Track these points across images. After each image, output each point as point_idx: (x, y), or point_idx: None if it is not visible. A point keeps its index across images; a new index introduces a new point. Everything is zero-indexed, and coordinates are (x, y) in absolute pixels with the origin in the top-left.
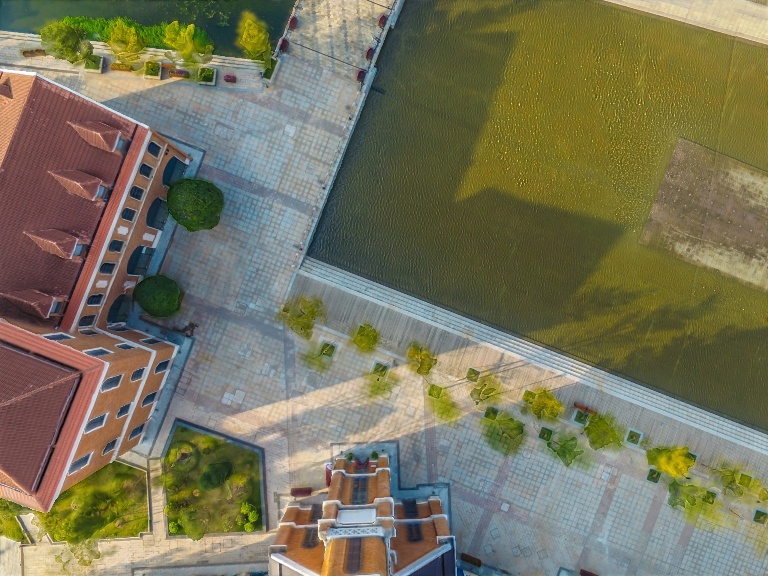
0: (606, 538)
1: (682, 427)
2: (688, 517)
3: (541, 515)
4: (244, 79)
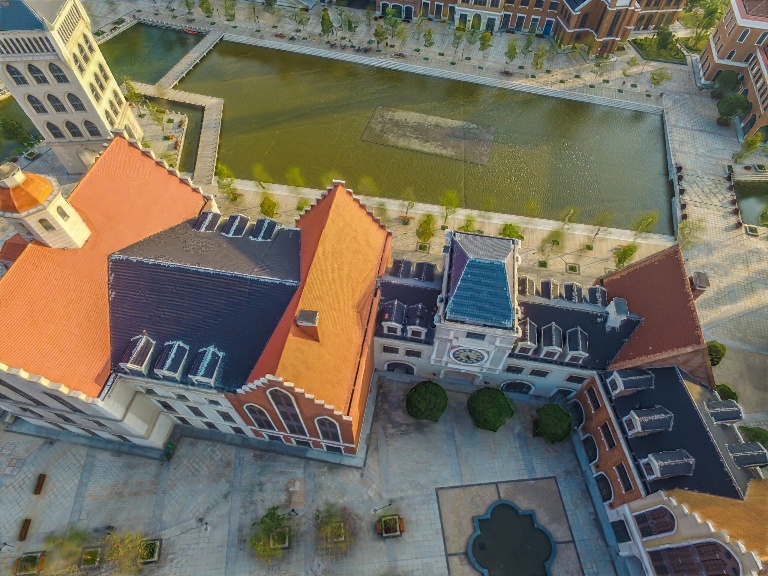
0: None
1: None
2: None
3: None
4: (740, 169)
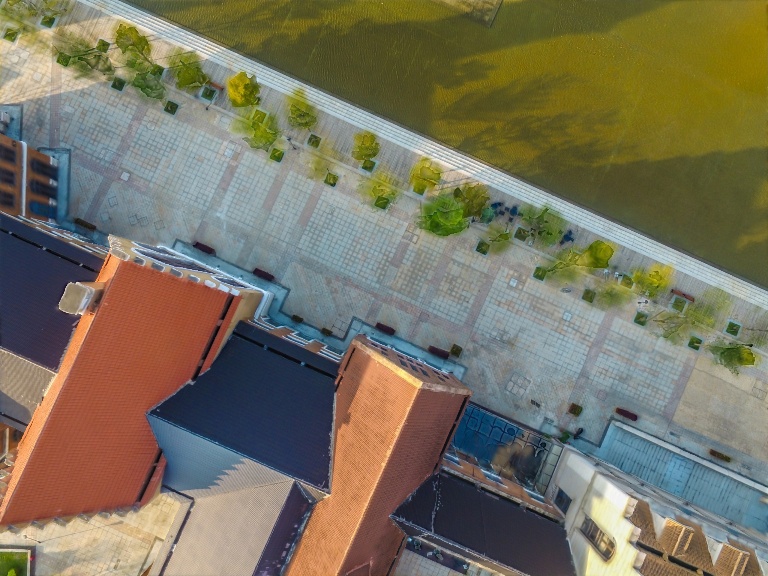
0: (225, 213)
1: (309, 109)
2: (309, 198)
3: (161, 186)
4: None
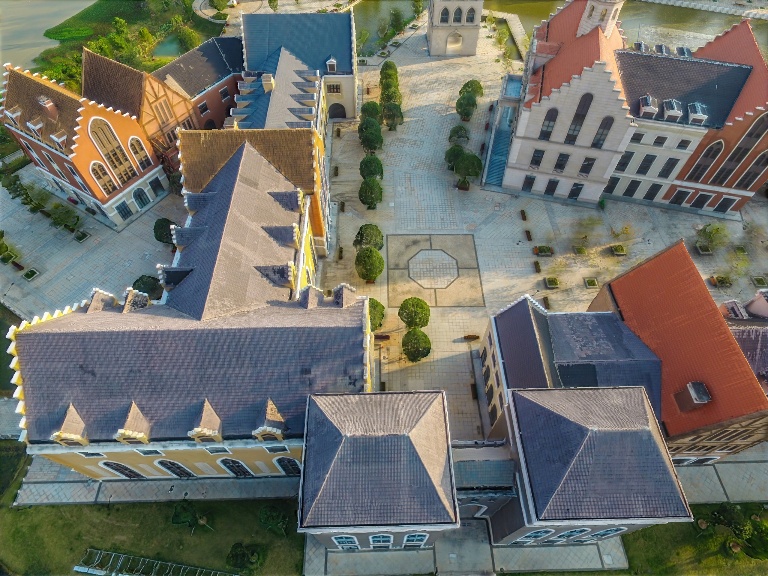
0: None
1: None
2: None
3: None
4: None
